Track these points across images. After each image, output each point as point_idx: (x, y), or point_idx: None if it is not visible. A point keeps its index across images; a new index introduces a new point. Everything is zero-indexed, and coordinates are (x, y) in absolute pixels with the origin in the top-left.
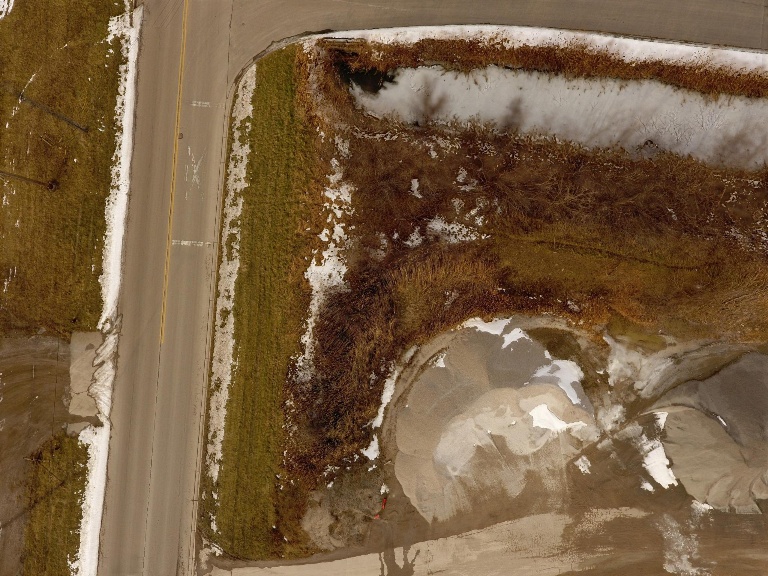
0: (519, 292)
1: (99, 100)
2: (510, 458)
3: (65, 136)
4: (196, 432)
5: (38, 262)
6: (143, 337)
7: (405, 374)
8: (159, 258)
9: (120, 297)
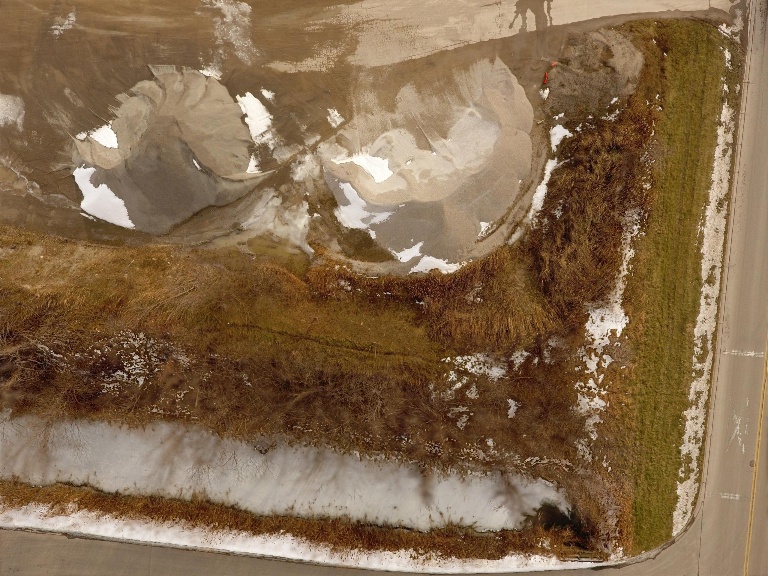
0: (402, 300)
1: None
2: (412, 126)
3: None
4: (744, 156)
5: None
6: None
7: (521, 215)
8: None
9: None
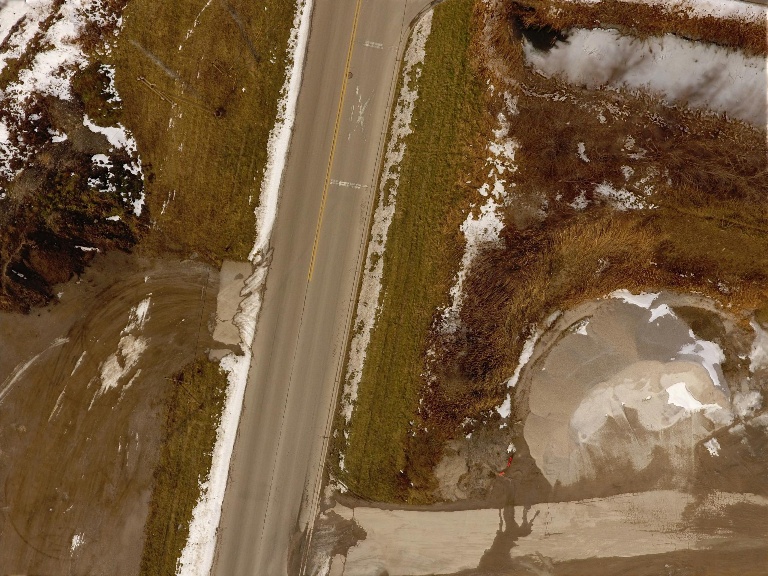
0: (671, 268)
1: (273, 31)
2: (640, 432)
3: (236, 64)
4: (334, 371)
5: (197, 188)
6: (292, 273)
7: (545, 337)
8: (316, 196)
9: (273, 231)
